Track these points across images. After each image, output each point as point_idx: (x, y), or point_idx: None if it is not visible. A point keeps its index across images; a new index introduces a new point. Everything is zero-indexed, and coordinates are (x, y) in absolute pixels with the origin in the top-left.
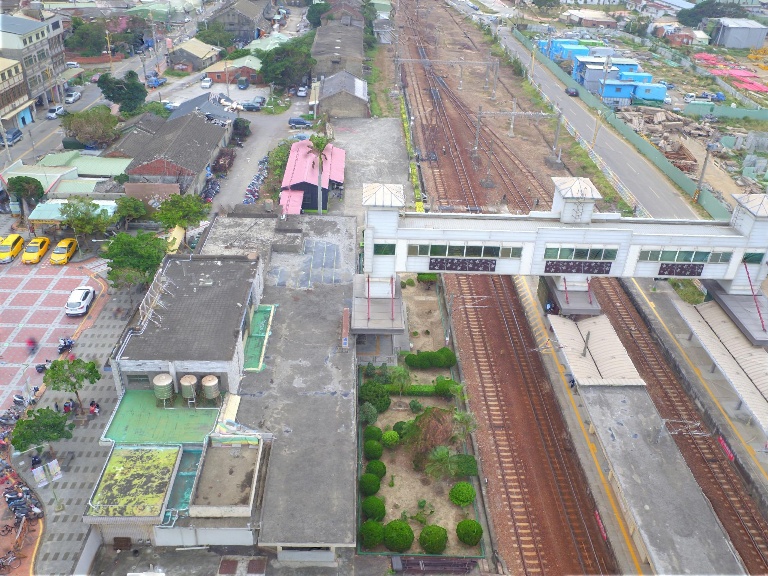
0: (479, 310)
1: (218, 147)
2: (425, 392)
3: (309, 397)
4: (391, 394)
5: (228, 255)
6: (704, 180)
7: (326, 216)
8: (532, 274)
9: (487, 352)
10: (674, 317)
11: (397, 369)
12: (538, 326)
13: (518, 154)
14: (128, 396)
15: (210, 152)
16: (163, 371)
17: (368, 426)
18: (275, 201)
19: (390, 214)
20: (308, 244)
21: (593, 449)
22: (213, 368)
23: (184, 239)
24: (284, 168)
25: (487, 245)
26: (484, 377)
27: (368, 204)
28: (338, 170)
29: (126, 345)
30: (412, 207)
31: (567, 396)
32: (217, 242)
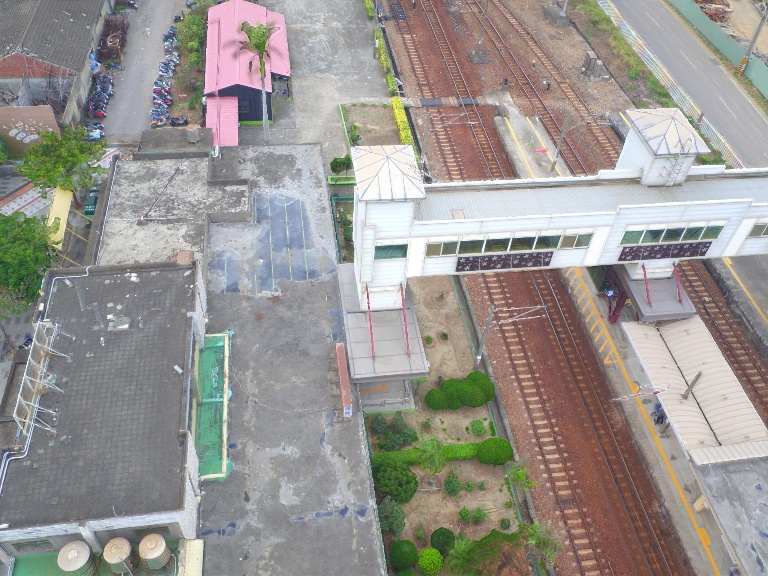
0: (505, 284)
1: (101, 16)
2: (462, 457)
3: (308, 525)
4: (414, 464)
5: (146, 263)
6: (741, 34)
7: (277, 146)
8: (600, 264)
9: (529, 362)
10: (759, 280)
11: (428, 446)
12: (591, 313)
13: (508, 3)
14: (21, 569)
15: (91, 30)
16: (72, 533)
17: (395, 541)
18: (197, 107)
19: (401, 206)
20: (260, 203)
21: (705, 539)
22: (154, 520)
23: (73, 196)
24: (201, 47)
25: (543, 235)
26: (532, 409)
27: (368, 198)
28: (280, 53)
29: (2, 486)
30: (387, 105)
31: (653, 441)
32: (124, 213)
